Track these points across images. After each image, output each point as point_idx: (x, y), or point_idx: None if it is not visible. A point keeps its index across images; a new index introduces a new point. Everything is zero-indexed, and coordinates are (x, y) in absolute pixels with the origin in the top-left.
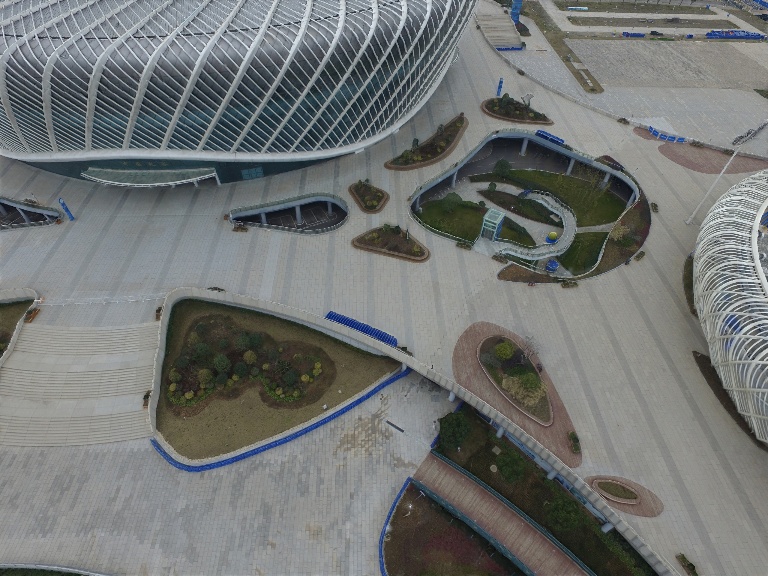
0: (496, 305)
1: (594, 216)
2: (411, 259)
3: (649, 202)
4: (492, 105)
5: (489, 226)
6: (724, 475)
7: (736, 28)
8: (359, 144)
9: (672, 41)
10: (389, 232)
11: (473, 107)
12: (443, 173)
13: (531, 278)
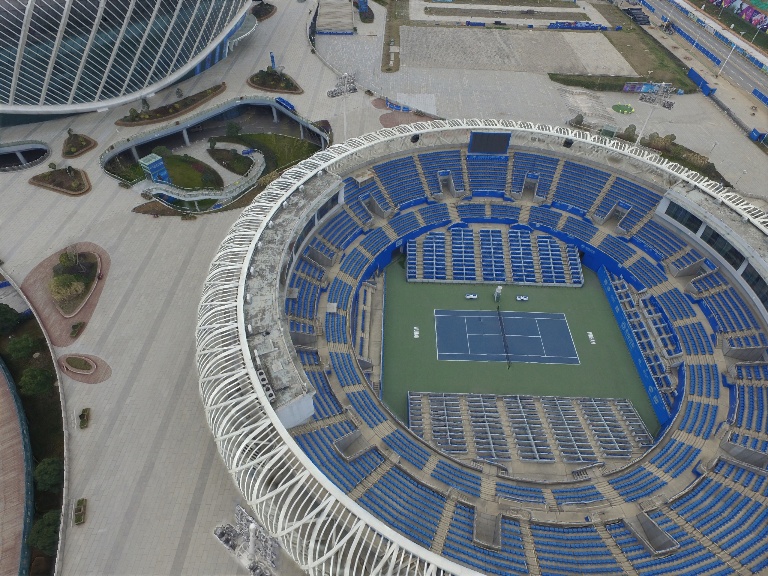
0: (110, 230)
1: None
2: (68, 193)
3: None
4: (256, 76)
5: (147, 168)
6: (183, 359)
7: (586, 20)
8: (98, 103)
9: (506, 30)
10: (64, 172)
11: (241, 78)
12: (159, 129)
13: (160, 211)
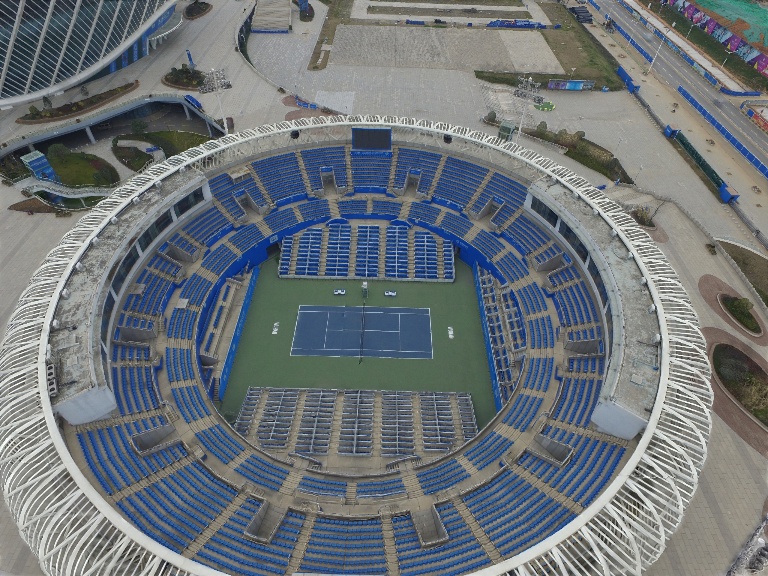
0: None
1: None
2: None
3: None
4: (171, 74)
5: None
6: None
7: (527, 18)
8: (1, 101)
9: (443, 28)
10: None
11: (157, 76)
12: (57, 127)
13: (36, 209)
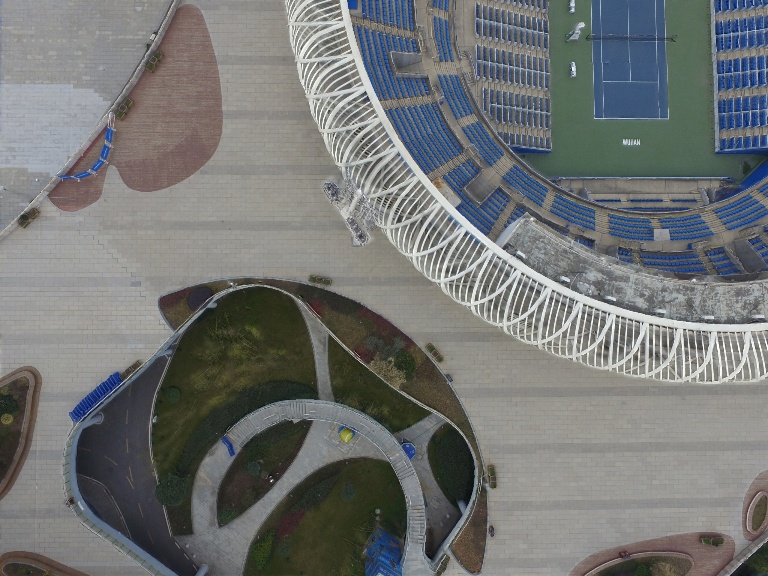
0: None
1: (291, 347)
2: None
3: (304, 282)
4: None
5: None
6: (741, 397)
7: None
8: None
9: None
10: None
11: None
12: None
13: (479, 528)
